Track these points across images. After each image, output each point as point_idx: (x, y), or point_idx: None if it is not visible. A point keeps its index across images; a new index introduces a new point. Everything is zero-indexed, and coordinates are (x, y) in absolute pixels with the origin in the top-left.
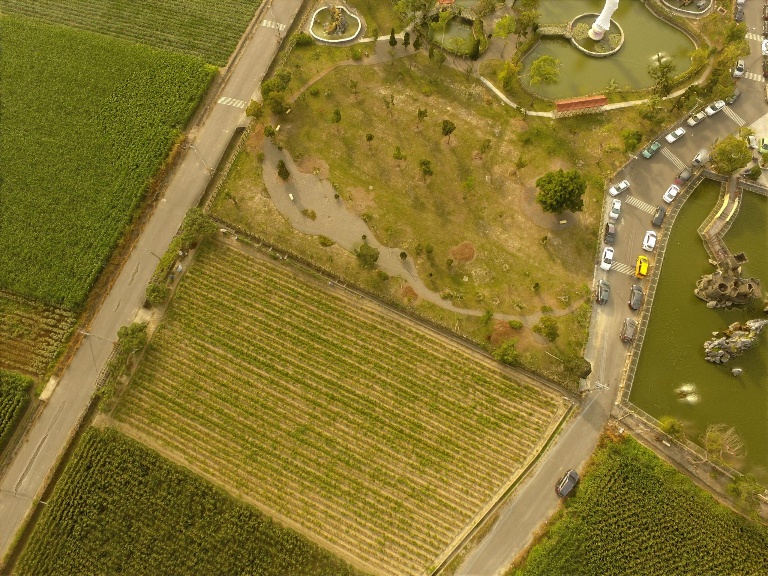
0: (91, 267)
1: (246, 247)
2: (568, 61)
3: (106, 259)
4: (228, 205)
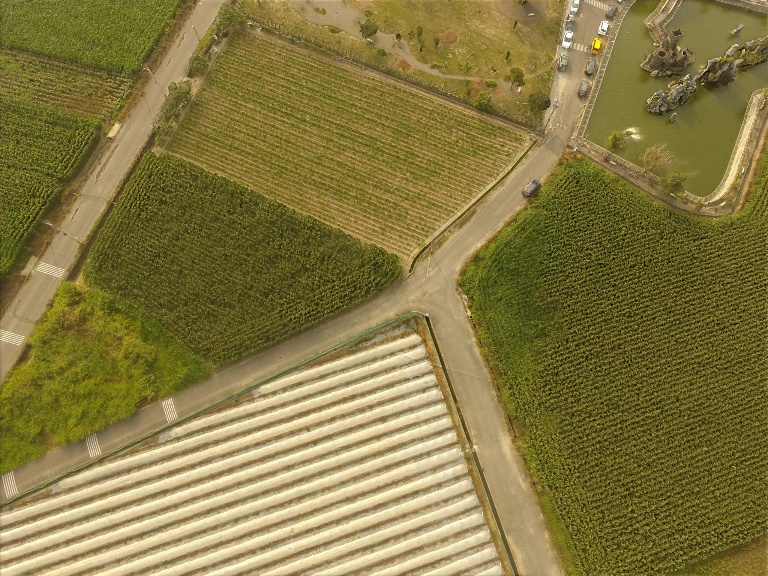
0: (144, 45)
1: (269, 36)
2: None
3: (155, 42)
4: (253, 6)
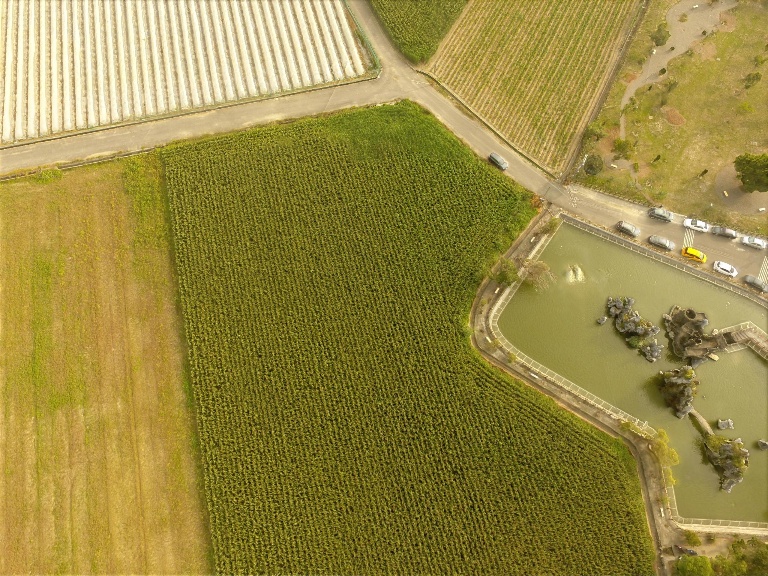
0: None
1: None
2: None
3: None
4: None
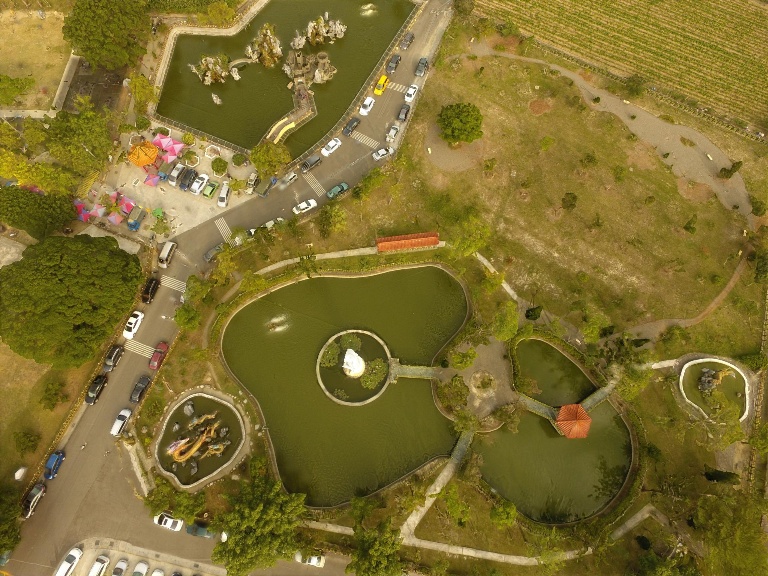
0: None
1: None
2: (400, 325)
3: None
4: (766, 157)
